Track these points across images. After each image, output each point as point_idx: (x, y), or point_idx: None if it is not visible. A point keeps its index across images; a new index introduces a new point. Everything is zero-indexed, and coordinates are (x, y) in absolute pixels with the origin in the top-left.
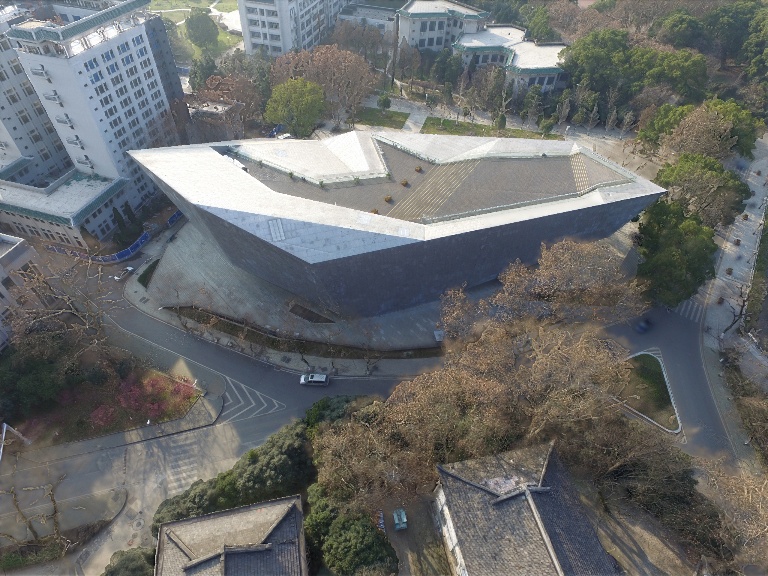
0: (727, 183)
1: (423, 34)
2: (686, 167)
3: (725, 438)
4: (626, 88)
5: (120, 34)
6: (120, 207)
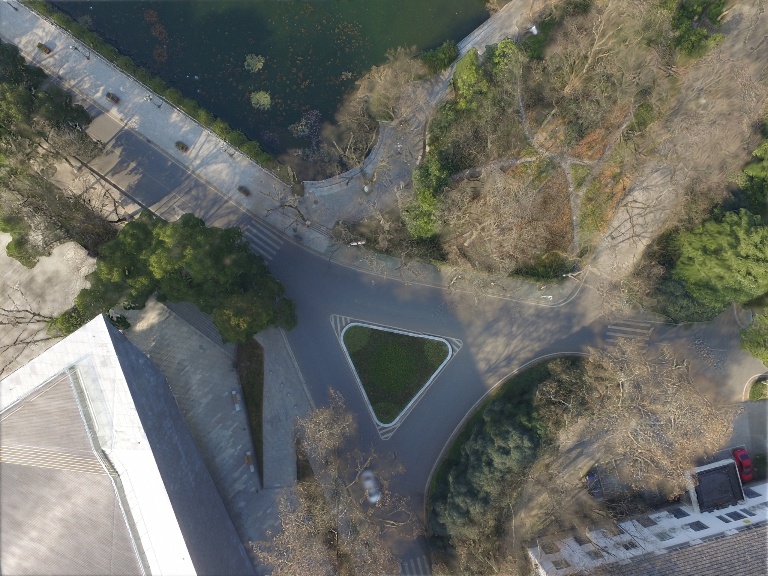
0: (11, 117)
1: None
2: None
3: (453, 295)
4: None
5: None
6: None
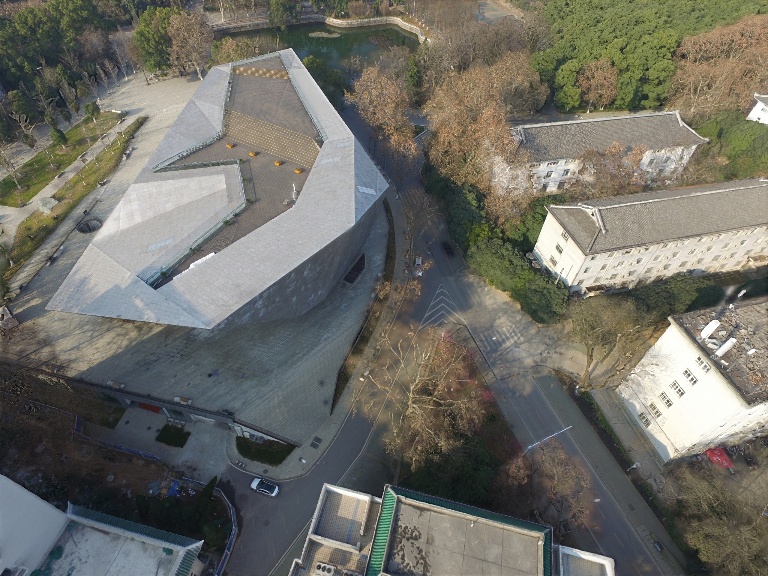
0: None
1: None
2: None
3: None
4: None
5: None
6: None
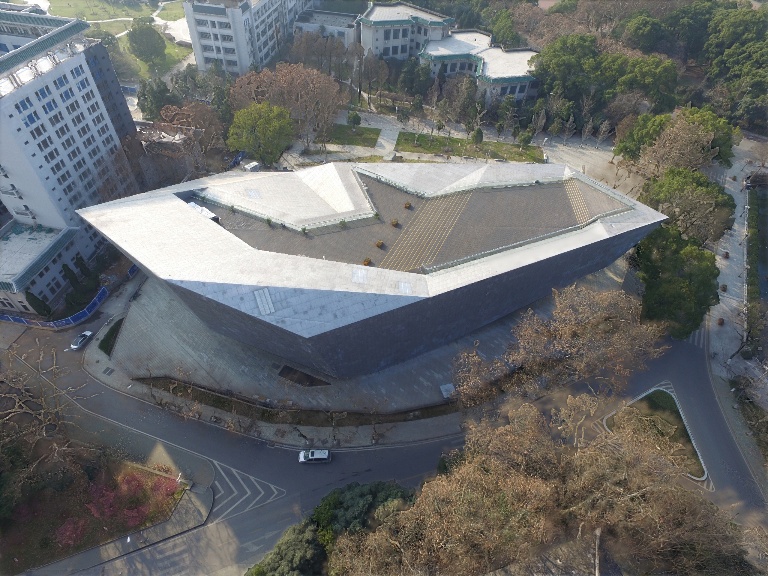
0: (716, 198)
1: (387, 42)
2: (675, 184)
3: (751, 480)
4: (599, 95)
5: (56, 67)
6: (71, 260)
